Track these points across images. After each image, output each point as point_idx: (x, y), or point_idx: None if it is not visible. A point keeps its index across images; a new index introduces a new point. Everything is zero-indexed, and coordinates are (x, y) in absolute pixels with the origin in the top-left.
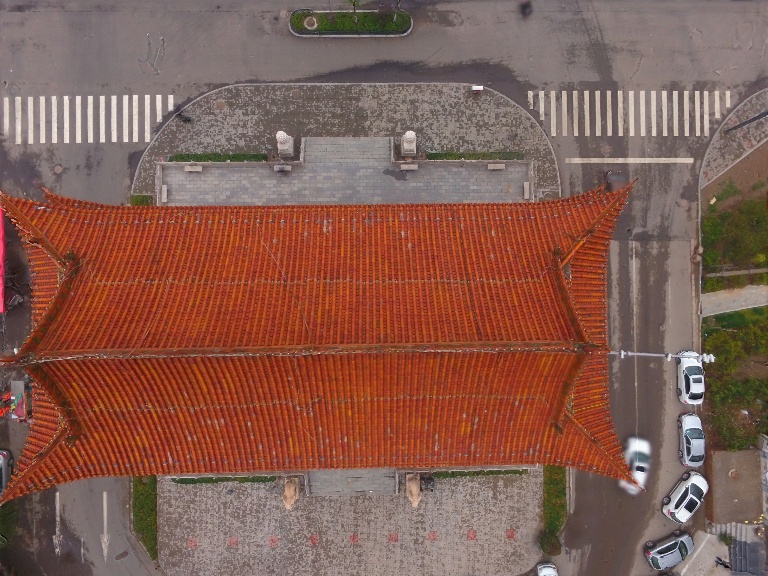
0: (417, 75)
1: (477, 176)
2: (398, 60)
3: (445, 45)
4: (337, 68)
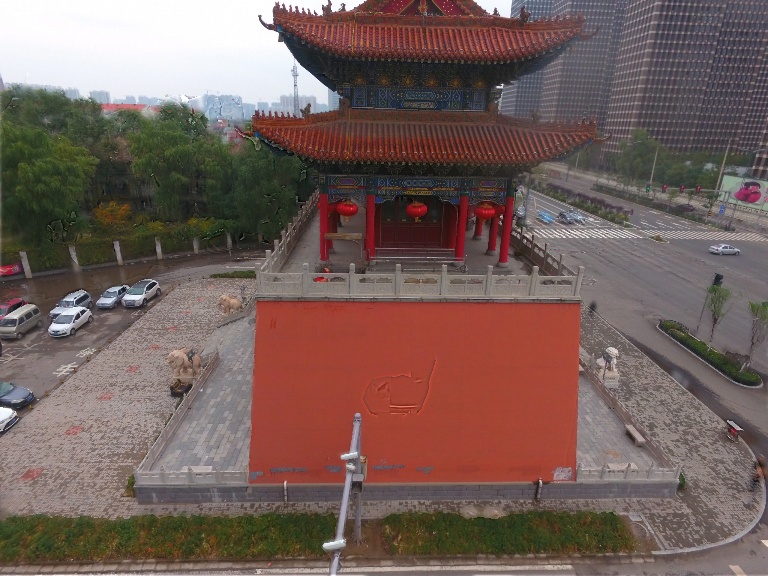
0: (698, 392)
1: (607, 421)
2: (700, 380)
3: (763, 414)
4: (649, 346)
